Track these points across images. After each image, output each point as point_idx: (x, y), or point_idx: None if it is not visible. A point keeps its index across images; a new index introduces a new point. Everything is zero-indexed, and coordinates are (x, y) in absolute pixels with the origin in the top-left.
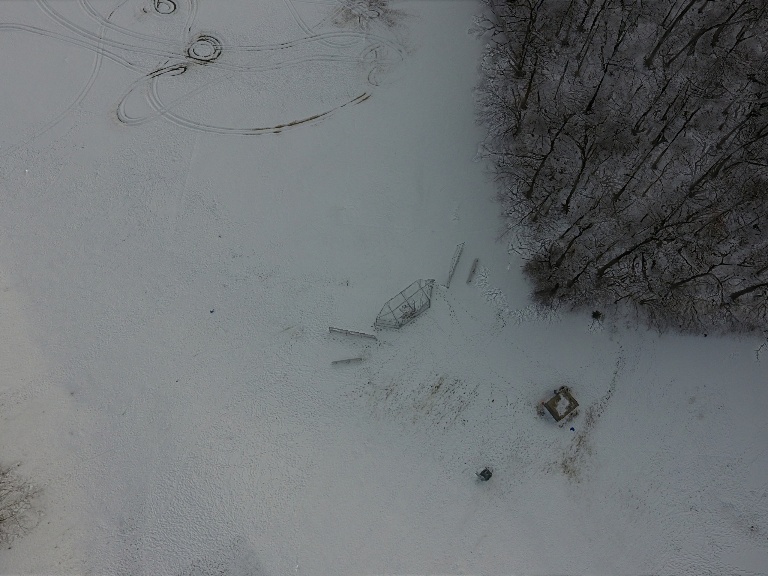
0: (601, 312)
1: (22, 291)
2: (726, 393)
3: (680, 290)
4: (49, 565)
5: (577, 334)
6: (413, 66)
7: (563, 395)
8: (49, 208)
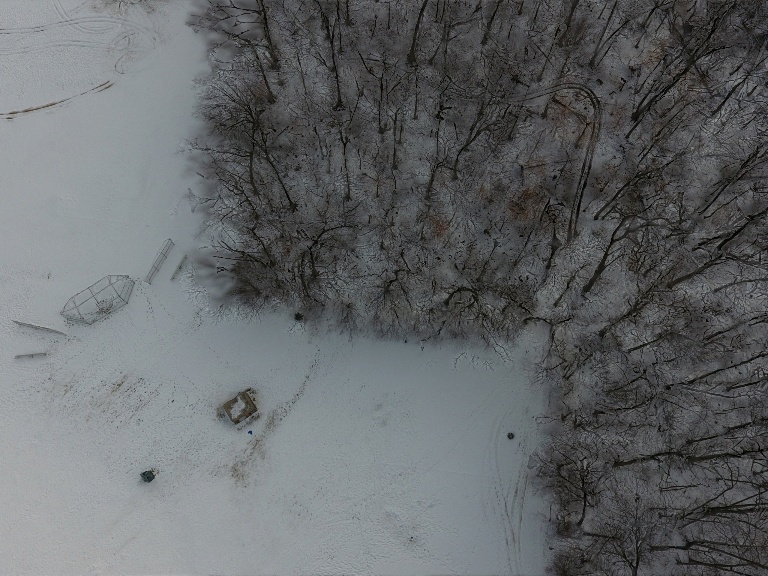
0: (303, 314)
1: None
2: (415, 401)
3: (390, 294)
4: None
5: (275, 336)
6: (164, 55)
7: (241, 398)
8: None
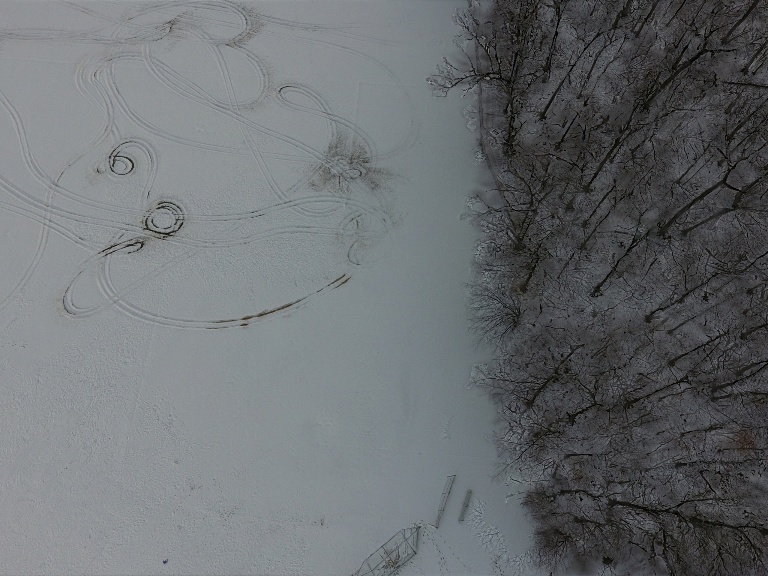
0: (613, 558)
1: None
2: None
3: None
4: None
5: None
6: (399, 240)
7: None
8: None
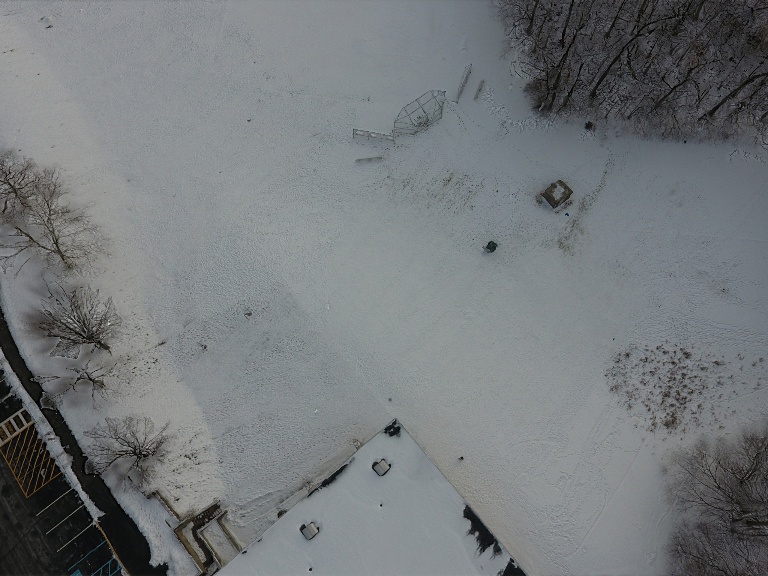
0: (593, 123)
1: (81, 103)
2: (703, 187)
3: (663, 106)
4: (116, 302)
5: (572, 141)
6: None
7: (559, 184)
8: (102, 39)
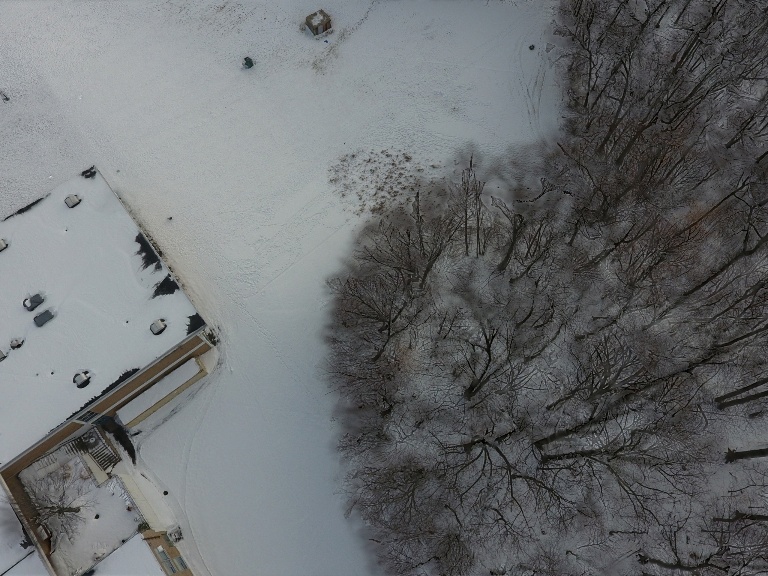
0: None
1: None
2: (455, 24)
3: None
4: None
5: None
6: None
7: (319, 12)
8: None
